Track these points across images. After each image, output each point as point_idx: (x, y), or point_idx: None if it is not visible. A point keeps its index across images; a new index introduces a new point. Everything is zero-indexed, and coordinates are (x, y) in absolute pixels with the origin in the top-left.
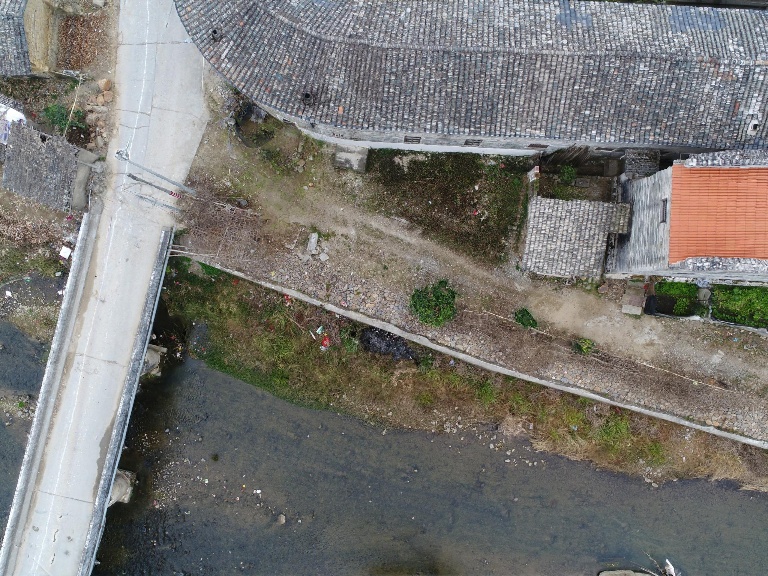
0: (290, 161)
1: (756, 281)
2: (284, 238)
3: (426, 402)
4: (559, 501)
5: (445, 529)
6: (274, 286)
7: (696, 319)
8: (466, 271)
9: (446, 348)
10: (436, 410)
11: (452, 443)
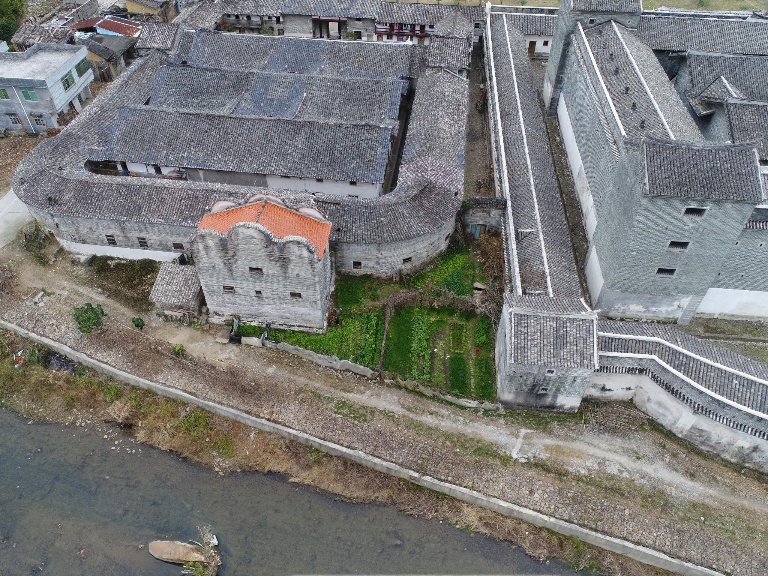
0: (47, 258)
1: (301, 326)
2: (23, 294)
3: (69, 400)
4: (142, 482)
5: (39, 497)
6: (3, 322)
7: (256, 341)
8: (125, 315)
9: (96, 361)
10: (76, 409)
11: (77, 433)
